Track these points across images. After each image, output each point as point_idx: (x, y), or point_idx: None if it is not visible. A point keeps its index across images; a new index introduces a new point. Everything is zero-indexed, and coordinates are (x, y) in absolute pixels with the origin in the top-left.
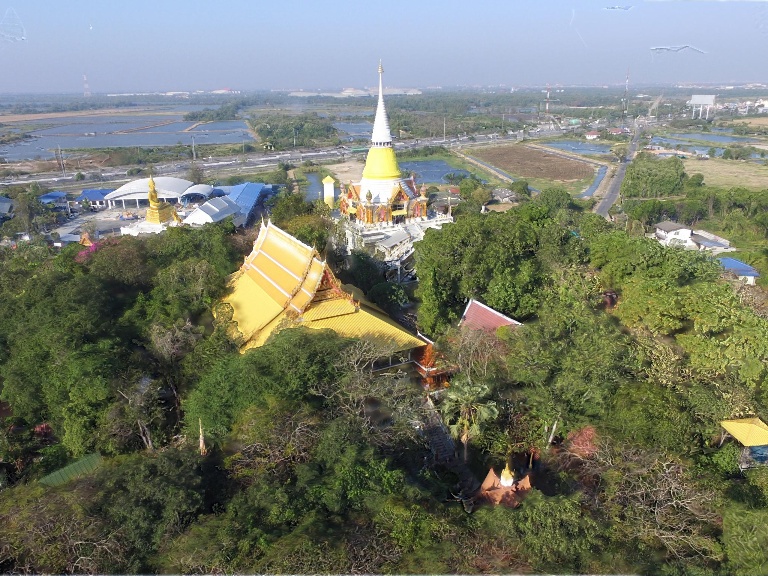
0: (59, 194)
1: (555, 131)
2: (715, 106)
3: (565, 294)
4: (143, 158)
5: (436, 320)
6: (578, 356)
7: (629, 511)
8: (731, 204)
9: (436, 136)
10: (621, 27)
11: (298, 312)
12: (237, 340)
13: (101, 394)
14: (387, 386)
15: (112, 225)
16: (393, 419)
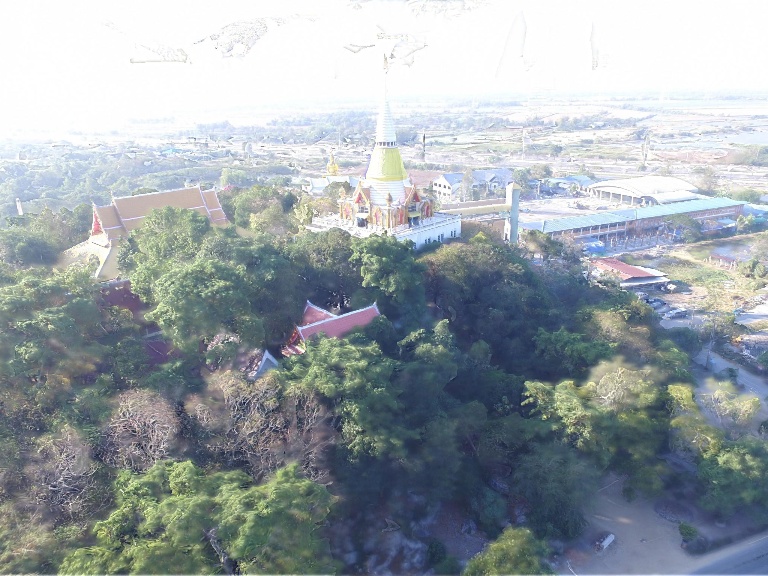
0: (581, 178)
1: None
2: None
3: None
4: (760, 160)
5: None
6: None
7: None
8: None
9: None
10: None
11: None
12: None
13: None
14: None
15: (552, 209)
16: None
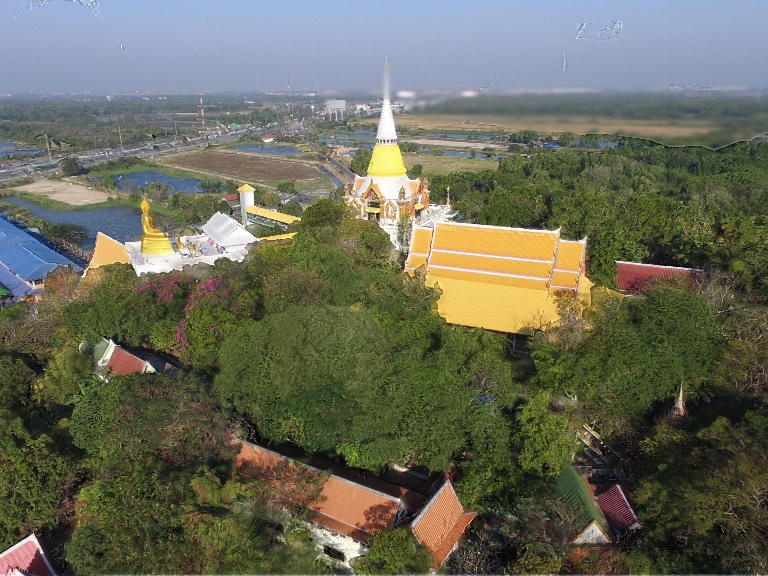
0: None
1: (232, 136)
2: (347, 109)
3: (700, 238)
4: None
5: None
6: None
7: None
8: (472, 184)
9: (111, 147)
10: None
11: (573, 290)
12: (525, 331)
13: (592, 392)
14: (761, 314)
15: None
16: (766, 339)
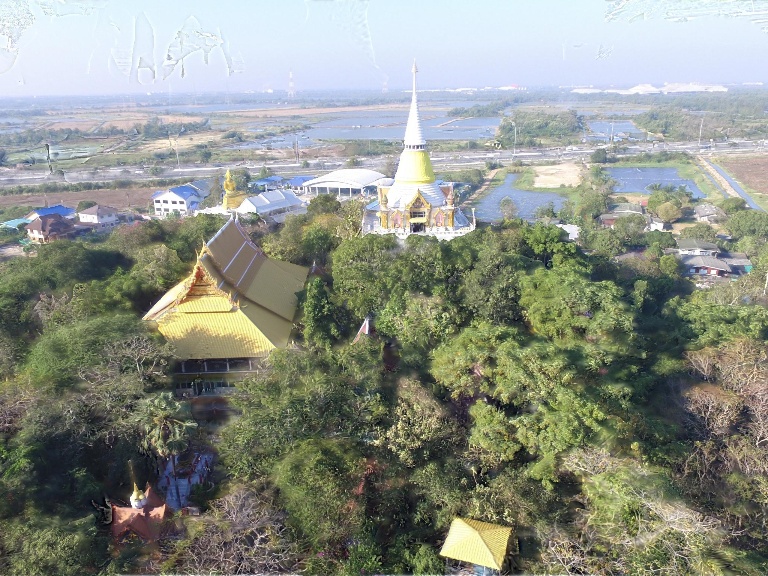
0: (276, 178)
1: None
2: None
3: (406, 328)
4: (372, 150)
5: (314, 334)
6: (288, 395)
7: (172, 571)
8: None
9: (689, 140)
10: (300, 23)
11: None
12: None
13: None
14: None
15: None
16: None
